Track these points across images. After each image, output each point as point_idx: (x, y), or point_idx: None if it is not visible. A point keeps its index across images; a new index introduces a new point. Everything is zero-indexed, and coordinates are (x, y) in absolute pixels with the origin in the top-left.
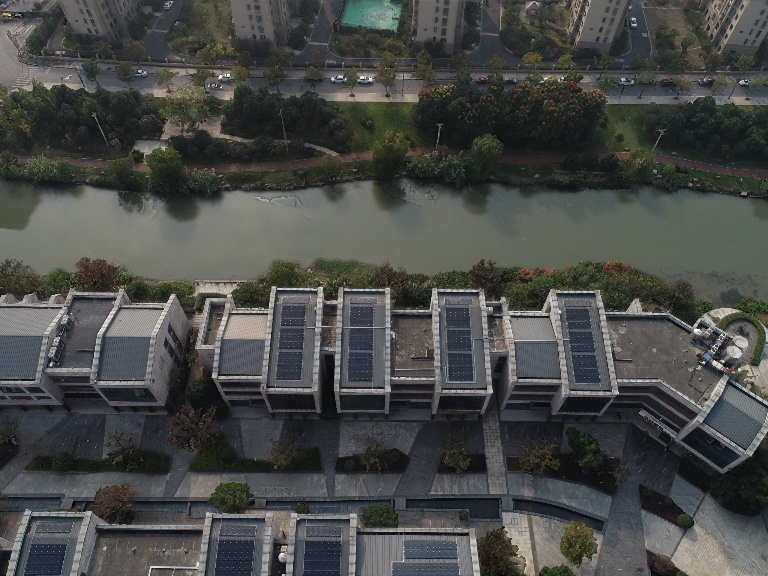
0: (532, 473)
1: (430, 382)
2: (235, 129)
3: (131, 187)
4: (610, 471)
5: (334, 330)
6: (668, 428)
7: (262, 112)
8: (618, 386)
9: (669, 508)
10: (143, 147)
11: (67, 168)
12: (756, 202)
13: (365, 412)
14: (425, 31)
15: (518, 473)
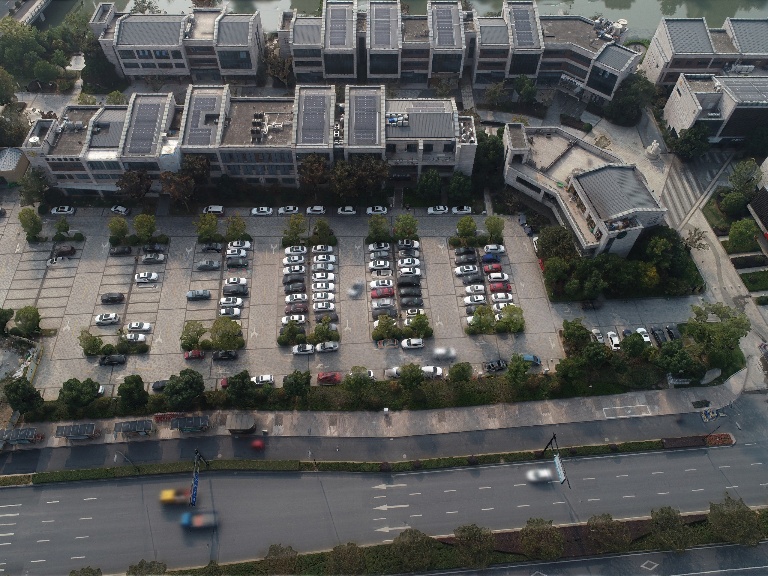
0: (492, 110)
1: (427, 47)
2: None
3: None
4: (542, 106)
5: (364, 26)
6: (579, 81)
7: None
8: (546, 50)
9: (578, 122)
10: None
11: None
12: None
13: (385, 77)
14: None
15: (484, 110)
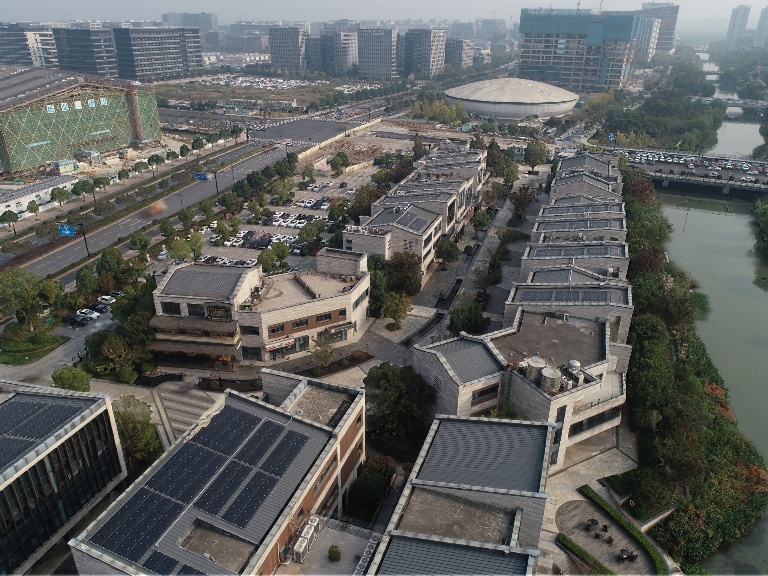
0: None
1: None
2: None
3: None
4: None
5: None
6: None
7: None
8: None
9: None
10: None
11: (767, 214)
12: None
13: None
14: None
15: None
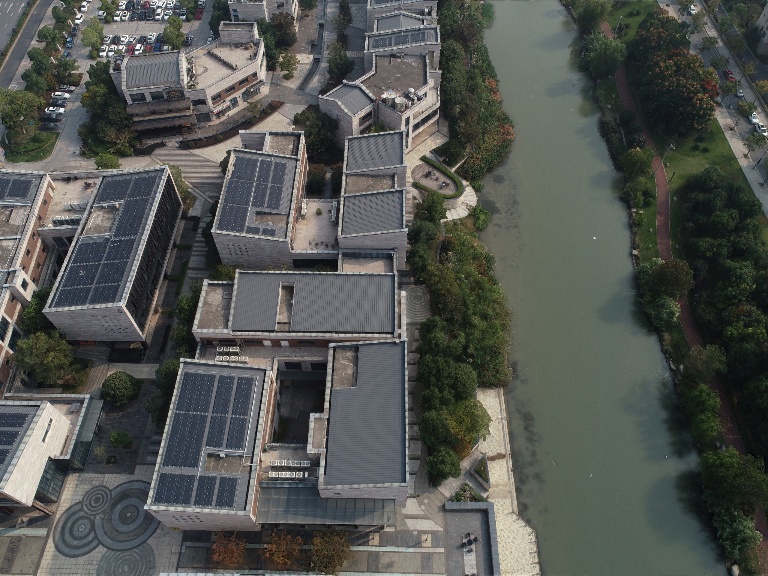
0: None
1: None
2: None
3: None
4: None
5: None
6: None
7: None
8: None
9: None
10: None
11: None
12: (627, 263)
13: None
14: (764, 16)
15: None
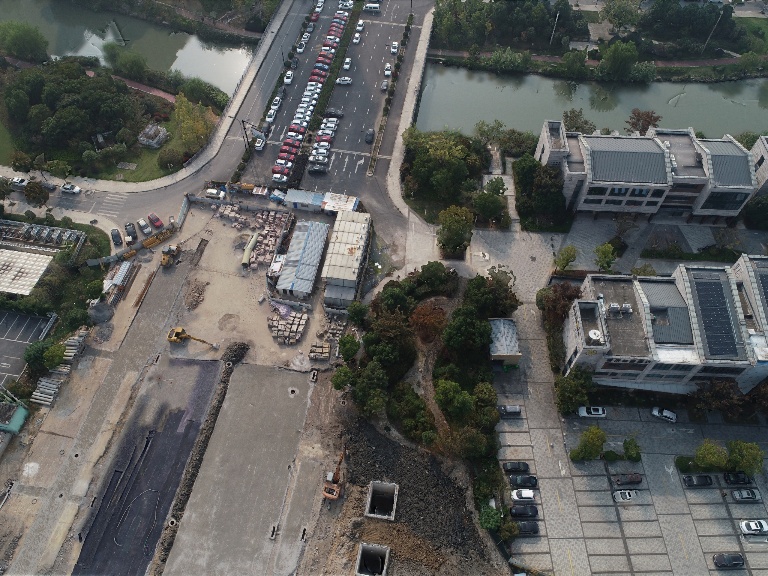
0: None
1: None
2: (650, 34)
3: (579, 77)
4: None
5: None
6: None
7: (680, 19)
8: None
9: None
10: (578, 46)
11: (529, 59)
12: None
13: None
14: None
15: None
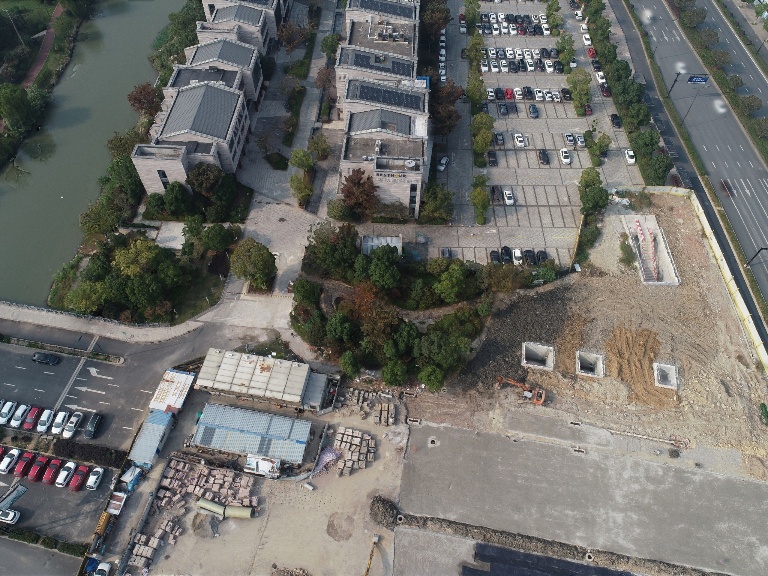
0: None
1: None
2: None
3: None
4: None
5: None
6: None
7: None
8: None
9: None
10: None
11: None
12: None
13: (286, 8)
14: None
15: None
